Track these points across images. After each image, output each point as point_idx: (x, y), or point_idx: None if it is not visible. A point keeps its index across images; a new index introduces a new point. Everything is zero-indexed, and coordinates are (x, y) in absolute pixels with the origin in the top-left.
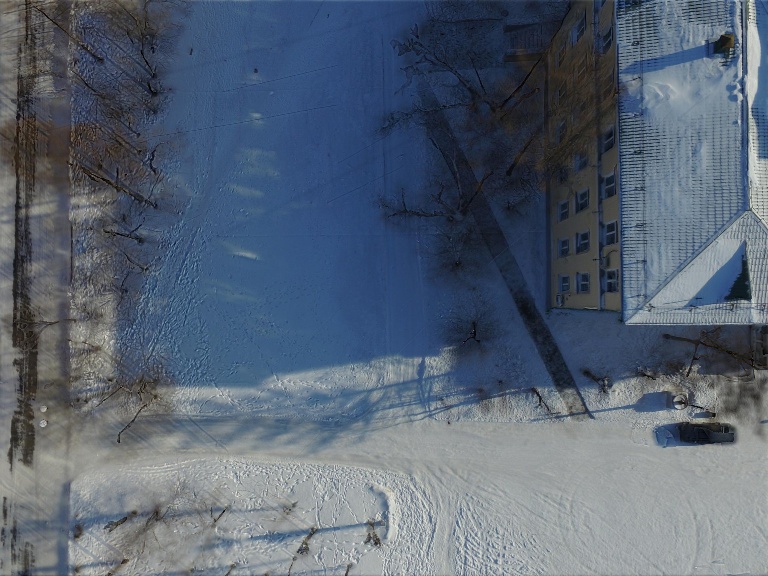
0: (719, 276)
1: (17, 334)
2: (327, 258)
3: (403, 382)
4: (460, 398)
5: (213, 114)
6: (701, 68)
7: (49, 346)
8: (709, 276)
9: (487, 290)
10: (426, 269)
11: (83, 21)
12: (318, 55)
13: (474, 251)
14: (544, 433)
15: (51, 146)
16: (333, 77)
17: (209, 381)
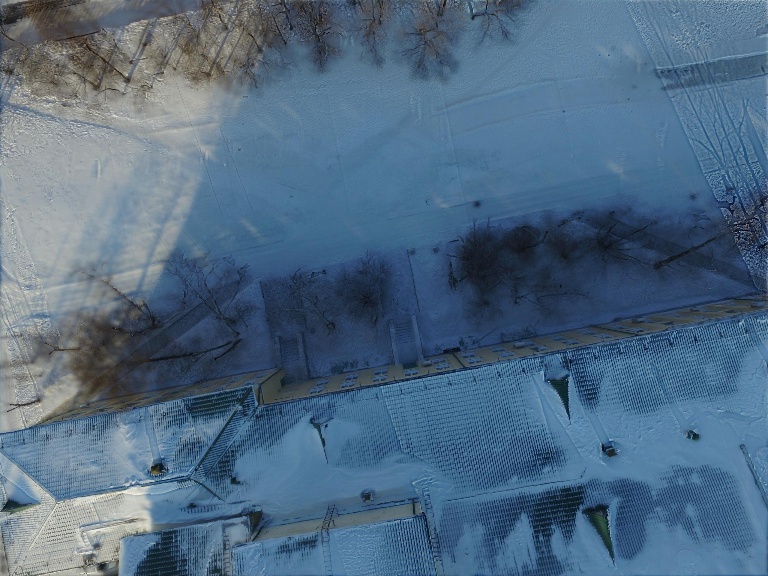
0: (19, 491)
1: (12, 7)
2: (108, 231)
3: (29, 305)
4: (25, 349)
5: (201, 123)
6: (146, 458)
7: (8, 33)
8: (19, 485)
9: (105, 354)
10: (114, 306)
11: (254, 8)
12: (259, 195)
13: (132, 340)
14: (11, 414)
15: (158, 2)
16: (244, 210)
17: (2, 160)
